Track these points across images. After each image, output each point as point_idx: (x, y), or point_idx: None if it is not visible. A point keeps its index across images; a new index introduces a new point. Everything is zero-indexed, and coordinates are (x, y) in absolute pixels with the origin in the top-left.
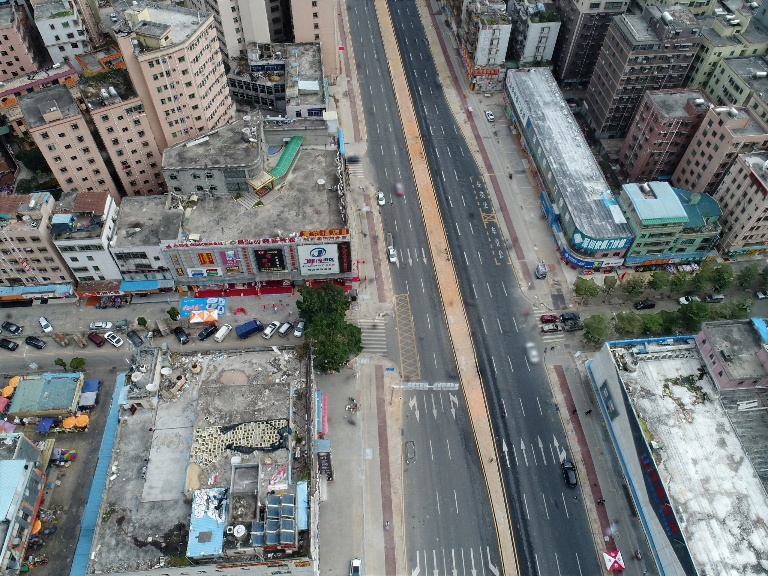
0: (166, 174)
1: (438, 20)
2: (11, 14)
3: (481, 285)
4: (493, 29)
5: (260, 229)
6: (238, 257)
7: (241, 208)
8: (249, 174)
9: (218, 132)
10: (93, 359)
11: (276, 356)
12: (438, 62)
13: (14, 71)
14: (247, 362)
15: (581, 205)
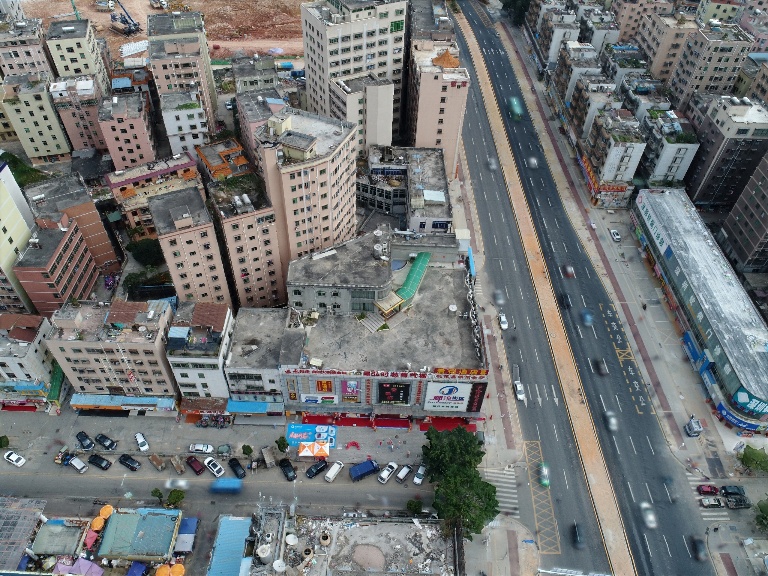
0: (290, 289)
1: (552, 126)
2: (139, 103)
3: (623, 438)
4: (626, 147)
5: (386, 358)
6: (360, 387)
7: (365, 330)
8: (378, 295)
9: (346, 245)
10: (190, 489)
11: (417, 531)
12: (555, 171)
13: (133, 158)
14: (383, 536)
15: (743, 357)
